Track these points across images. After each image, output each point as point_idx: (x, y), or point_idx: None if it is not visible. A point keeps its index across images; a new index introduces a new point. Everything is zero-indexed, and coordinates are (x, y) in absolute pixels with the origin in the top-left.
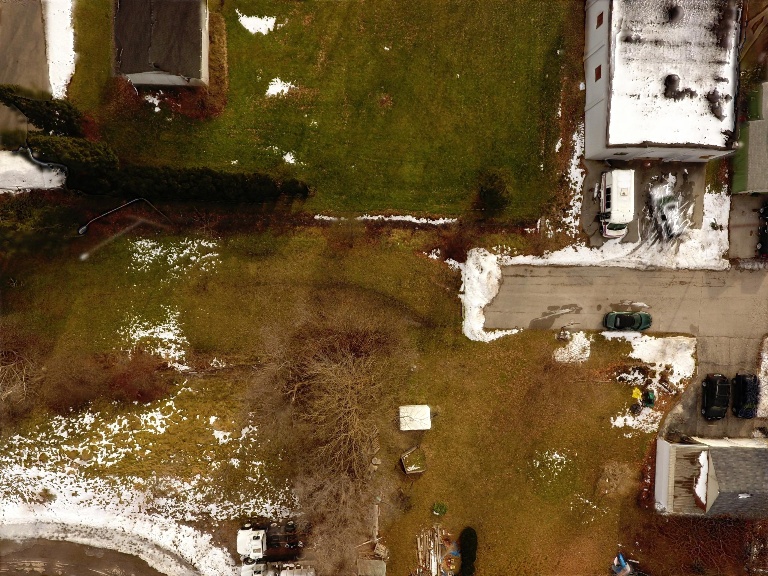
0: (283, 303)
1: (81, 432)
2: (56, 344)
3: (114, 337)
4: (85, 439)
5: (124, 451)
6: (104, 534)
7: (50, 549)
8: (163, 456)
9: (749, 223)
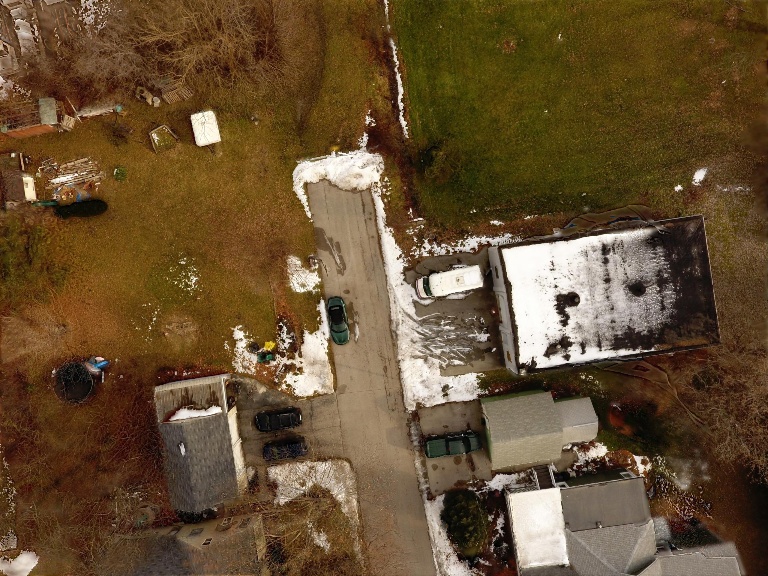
0: None
1: None
2: None
3: None
4: None
5: None
6: None
7: None
8: None
9: (455, 422)
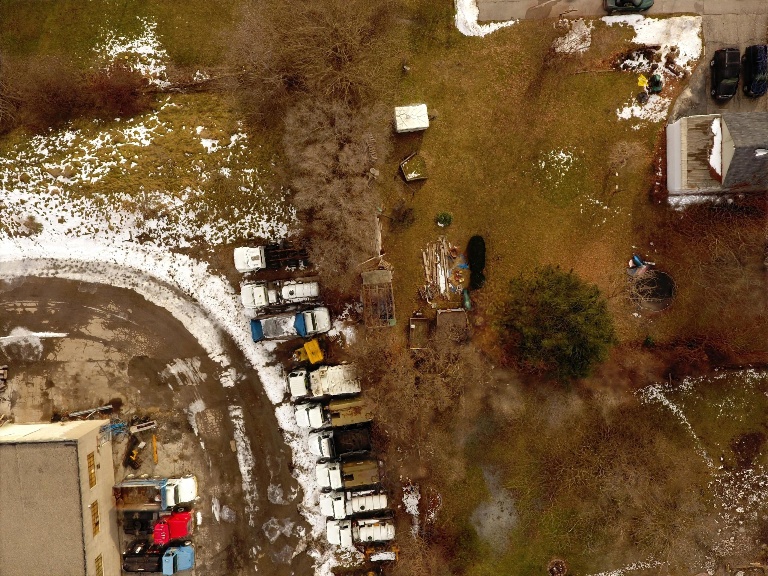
0: (265, 5)
1: (62, 148)
2: (30, 67)
3: (90, 55)
4: (67, 155)
5: (109, 165)
6: (96, 268)
7: (40, 287)
8: (150, 168)
9: None
